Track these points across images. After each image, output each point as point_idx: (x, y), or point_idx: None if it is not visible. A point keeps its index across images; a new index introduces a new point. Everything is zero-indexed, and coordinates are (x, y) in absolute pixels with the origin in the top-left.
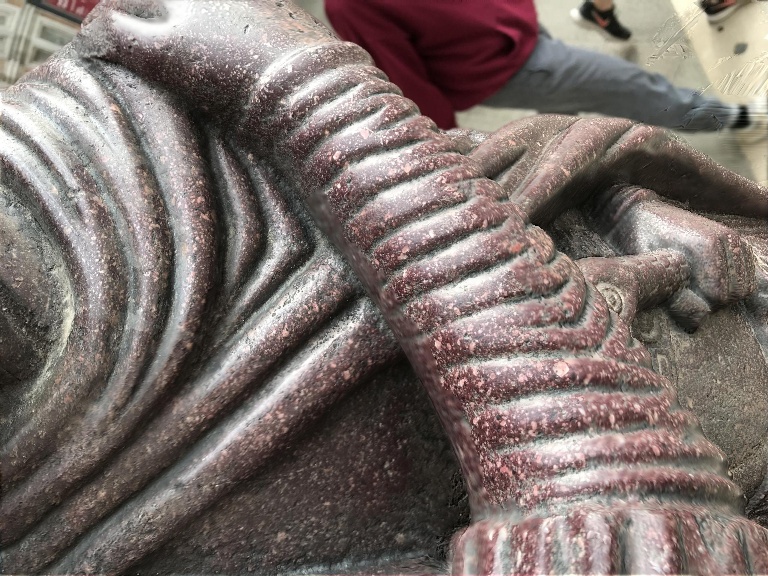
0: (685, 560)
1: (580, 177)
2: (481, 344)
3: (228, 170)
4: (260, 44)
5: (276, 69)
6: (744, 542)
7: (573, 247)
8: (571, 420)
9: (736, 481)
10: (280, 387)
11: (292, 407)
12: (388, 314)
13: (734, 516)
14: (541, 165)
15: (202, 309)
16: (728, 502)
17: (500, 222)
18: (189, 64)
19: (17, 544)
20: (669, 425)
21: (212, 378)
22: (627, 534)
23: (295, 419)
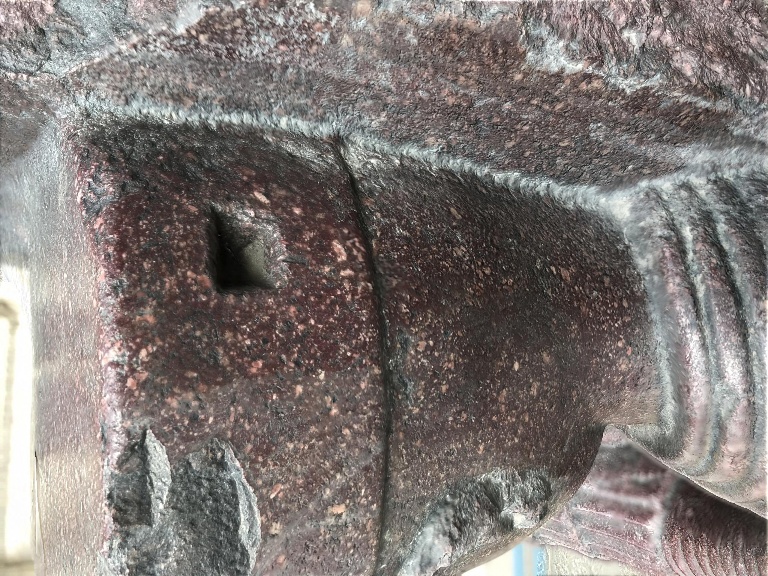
0: None
1: None
2: (714, 570)
3: None
4: None
5: None
6: None
7: None
8: (695, 575)
9: None
10: None
11: None
12: (736, 527)
13: None
14: None
15: None
16: None
17: None
18: None
19: None
20: None
21: None
22: None
23: None
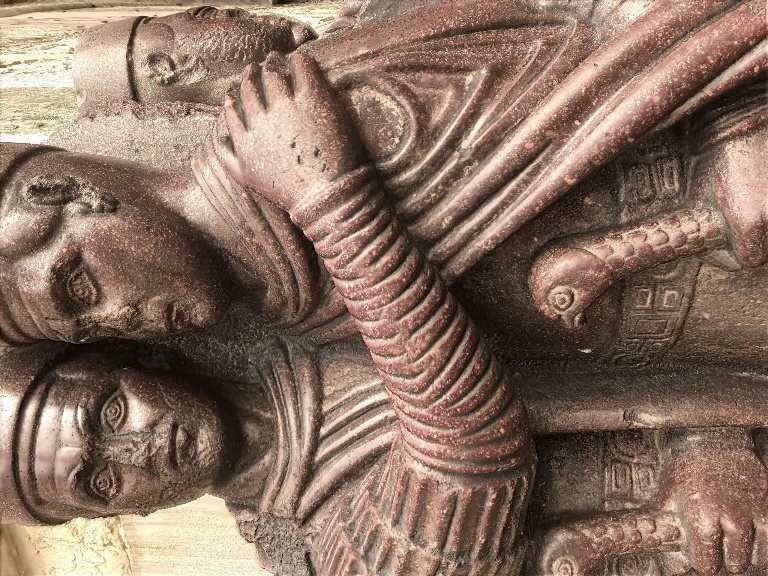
0: (426, 491)
1: (612, 159)
2: None
3: None
4: (282, 196)
5: (291, 215)
6: (457, 495)
7: (622, 191)
8: None
9: (767, 352)
10: None
11: None
12: None
13: (467, 483)
14: (550, 171)
15: (310, 289)
16: (475, 475)
17: (393, 336)
18: None
19: None
20: (452, 445)
21: (327, 306)
22: None
23: None
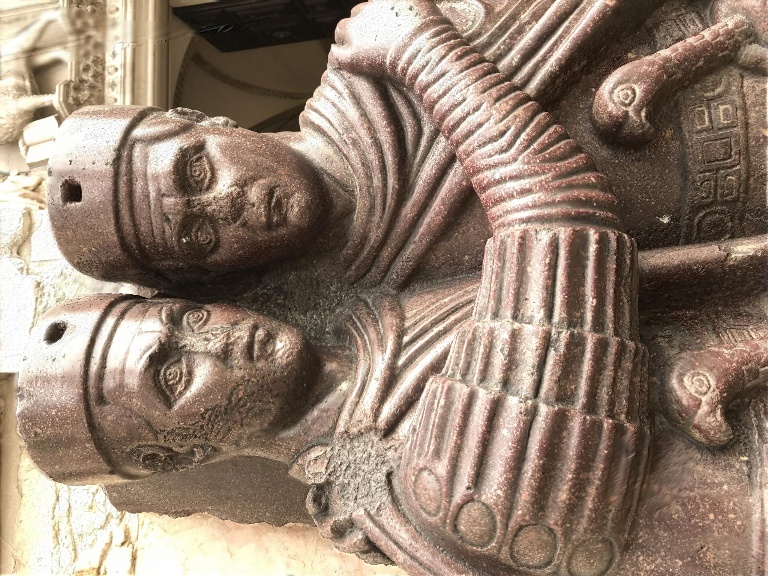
0: (525, 247)
1: None
2: (473, 170)
3: (397, 100)
4: (382, 44)
5: (389, 56)
6: (557, 237)
7: (657, 40)
8: (499, 197)
9: None
10: (439, 195)
11: (445, 202)
12: None
13: (567, 226)
14: (593, 5)
15: (398, 170)
16: (573, 220)
17: (479, 107)
18: (362, 64)
19: (370, 270)
20: (545, 190)
21: (412, 197)
22: (508, 240)
23: (448, 207)
